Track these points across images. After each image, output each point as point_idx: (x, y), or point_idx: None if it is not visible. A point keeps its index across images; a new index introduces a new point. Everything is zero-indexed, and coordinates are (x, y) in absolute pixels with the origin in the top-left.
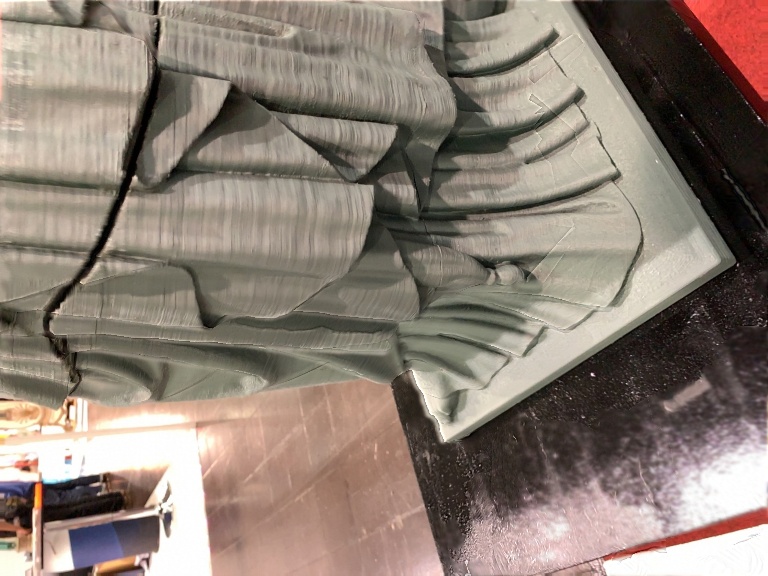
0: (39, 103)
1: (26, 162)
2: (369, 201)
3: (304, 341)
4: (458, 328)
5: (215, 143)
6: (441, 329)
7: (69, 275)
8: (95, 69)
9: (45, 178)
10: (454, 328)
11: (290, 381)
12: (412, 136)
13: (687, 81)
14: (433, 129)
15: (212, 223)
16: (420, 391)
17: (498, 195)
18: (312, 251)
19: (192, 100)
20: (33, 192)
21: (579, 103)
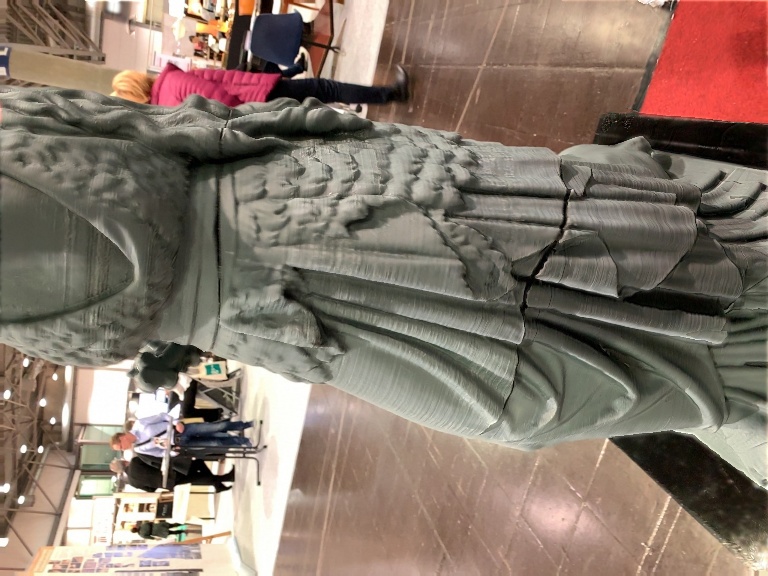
0: (517, 167)
1: (524, 184)
2: (687, 208)
3: (670, 320)
4: (760, 351)
5: (595, 186)
6: (746, 355)
7: (553, 237)
8: None
9: (532, 192)
10: (756, 351)
11: (644, 414)
12: (679, 205)
13: None
14: (690, 199)
15: (613, 214)
16: (732, 494)
17: (749, 231)
18: (671, 228)
19: (576, 170)
20: (527, 199)
21: (766, 190)
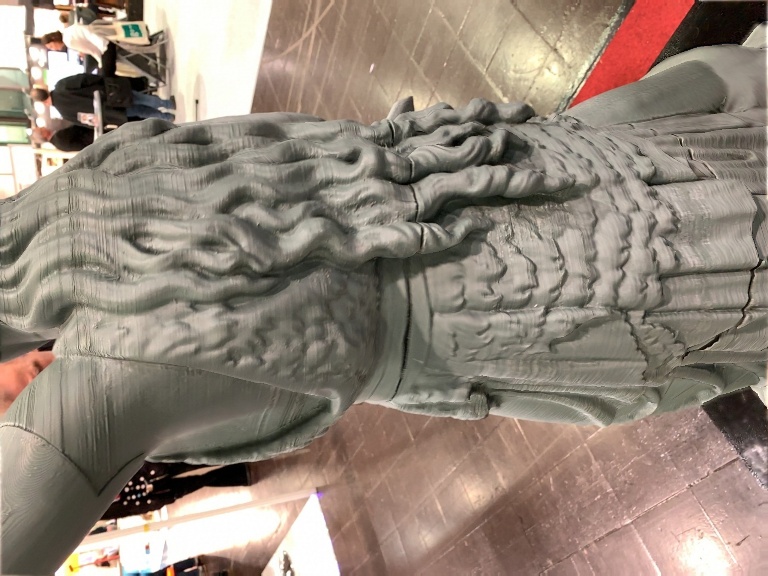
0: (714, 227)
1: (722, 261)
2: None
3: None
4: None
5: None
6: None
7: (734, 324)
8: (732, 202)
9: (725, 269)
10: None
11: None
12: None
13: None
14: None
15: None
16: (737, 399)
17: None
18: None
19: (763, 210)
20: (719, 278)
21: None
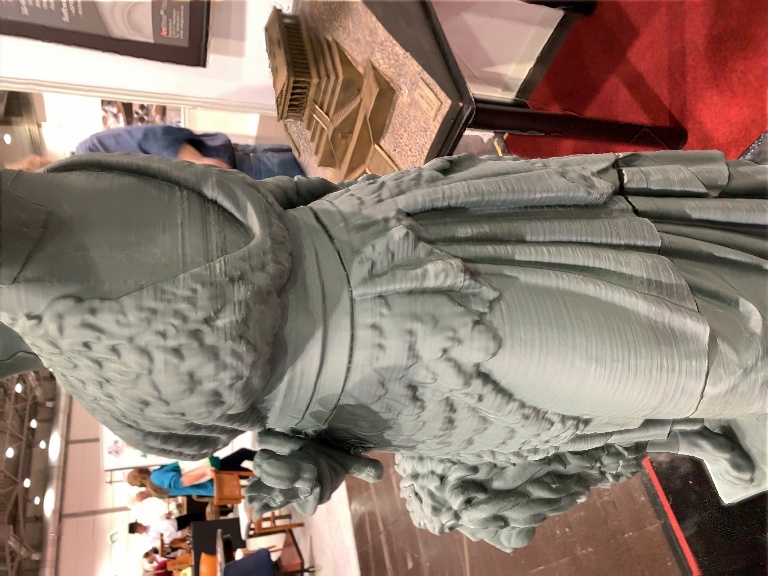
0: None
1: None
2: None
3: None
4: None
5: None
6: None
7: (613, 156)
8: None
9: None
10: None
11: None
12: None
13: (759, 154)
14: None
15: None
16: None
17: None
18: None
19: None
20: None
21: None
